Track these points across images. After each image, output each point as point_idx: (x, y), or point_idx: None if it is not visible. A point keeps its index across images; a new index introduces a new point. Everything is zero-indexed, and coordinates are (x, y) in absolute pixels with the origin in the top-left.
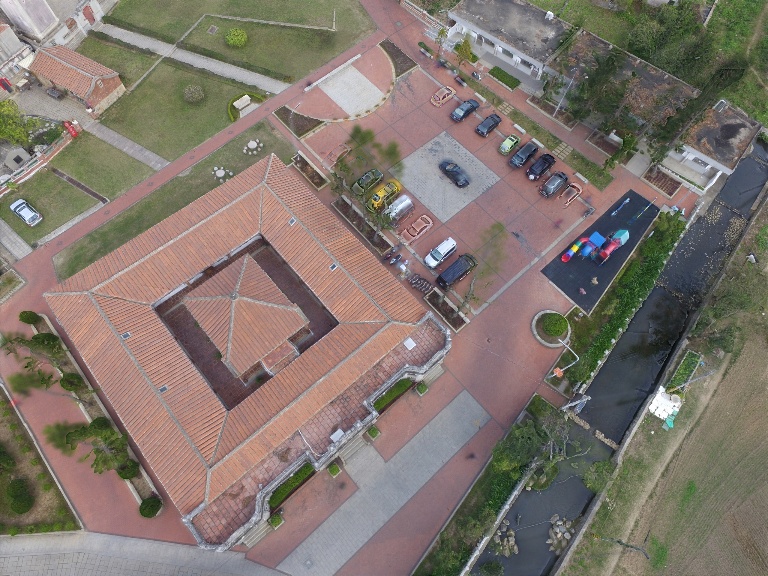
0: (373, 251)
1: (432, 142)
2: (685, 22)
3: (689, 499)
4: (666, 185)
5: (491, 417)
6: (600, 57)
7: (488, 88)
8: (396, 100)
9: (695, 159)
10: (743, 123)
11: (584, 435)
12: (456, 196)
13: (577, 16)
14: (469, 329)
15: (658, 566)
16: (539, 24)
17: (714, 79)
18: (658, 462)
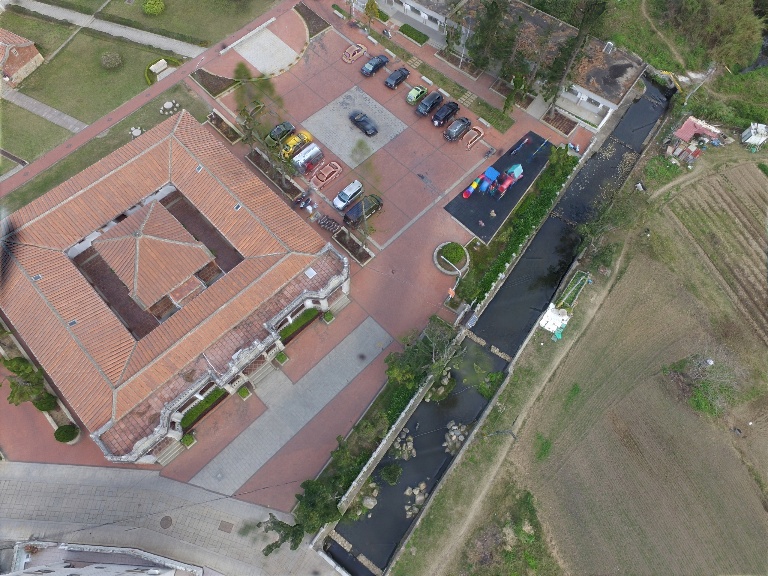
0: (285, 197)
1: (343, 96)
2: None
3: (573, 399)
4: (563, 125)
5: (393, 339)
6: (488, 4)
7: (398, 44)
8: (309, 59)
9: (588, 99)
10: (630, 63)
11: (481, 351)
12: (365, 144)
13: None
14: (375, 263)
15: (542, 458)
16: None
17: (585, 15)
18: (546, 369)
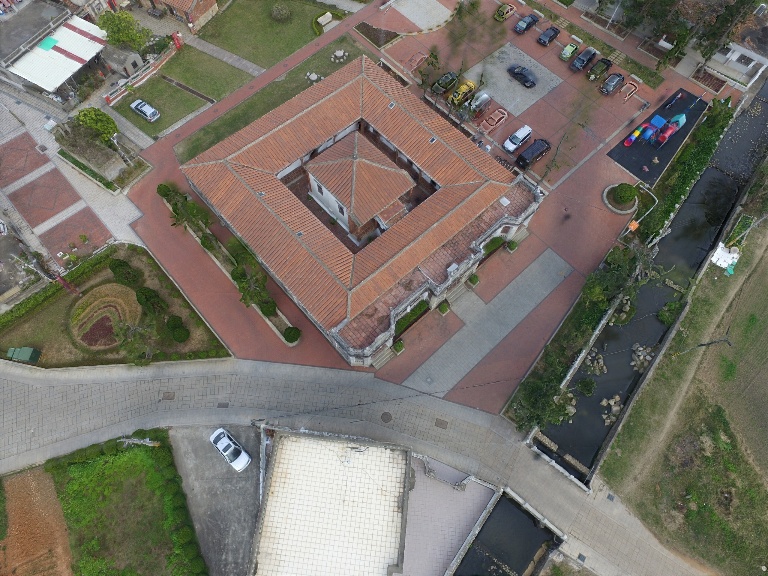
0: None
1: (499, 51)
2: None
3: (751, 328)
4: (712, 83)
5: (574, 269)
6: None
7: (545, 6)
8: (463, 17)
9: (738, 59)
10: None
11: (655, 283)
12: (525, 95)
13: None
14: (548, 201)
15: (729, 378)
16: None
17: None
18: (722, 300)
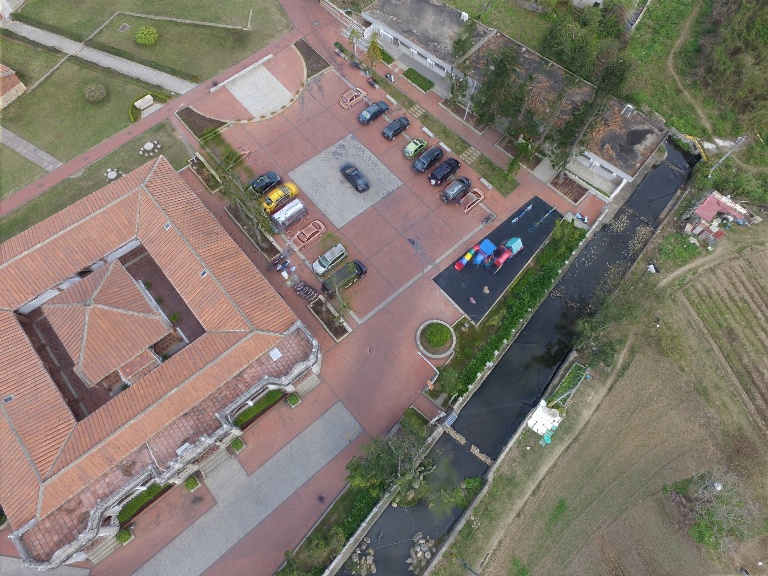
0: (261, 257)
1: (337, 145)
2: (608, 24)
3: (558, 518)
4: (572, 192)
5: (363, 430)
6: (497, 60)
7: (401, 90)
8: (305, 102)
9: None
10: (651, 129)
11: (459, 450)
12: (354, 201)
13: (500, 17)
14: (351, 338)
15: None
16: (453, 25)
17: (600, 84)
18: (530, 479)
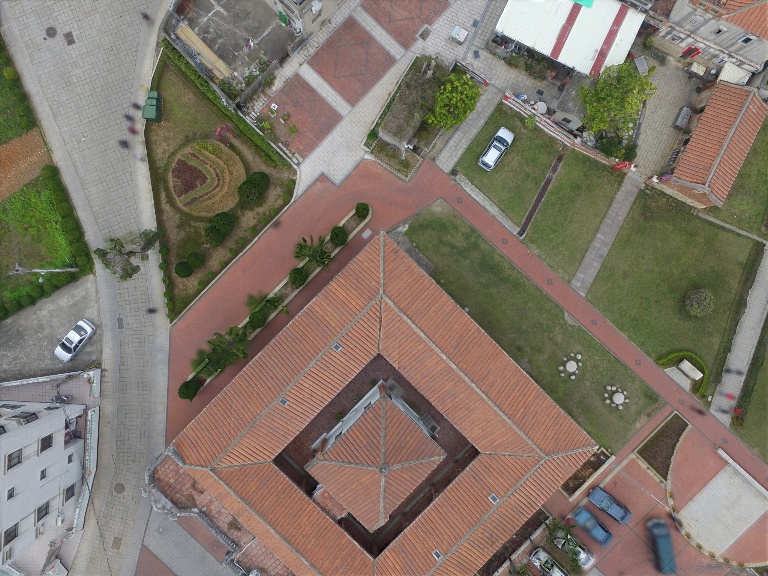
0: None
1: None
2: None
3: None
4: None
5: None
6: None
7: None
8: (712, 569)
9: None
10: None
11: None
12: None
13: None
14: None
15: None
16: None
17: None
18: None
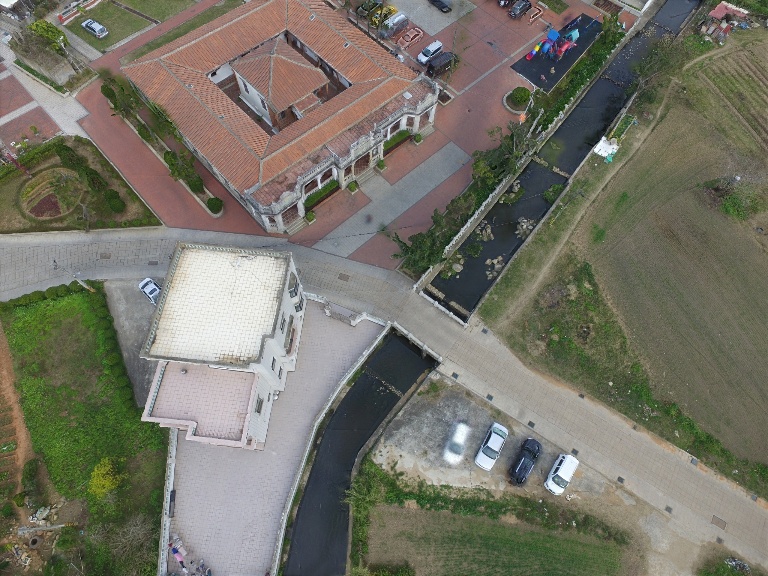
0: None
1: None
2: None
3: (622, 203)
4: (611, 9)
5: (472, 158)
6: None
7: None
8: None
9: None
10: None
11: (544, 171)
12: (441, 18)
13: None
14: (454, 104)
15: (598, 241)
16: None
17: None
18: (600, 182)
